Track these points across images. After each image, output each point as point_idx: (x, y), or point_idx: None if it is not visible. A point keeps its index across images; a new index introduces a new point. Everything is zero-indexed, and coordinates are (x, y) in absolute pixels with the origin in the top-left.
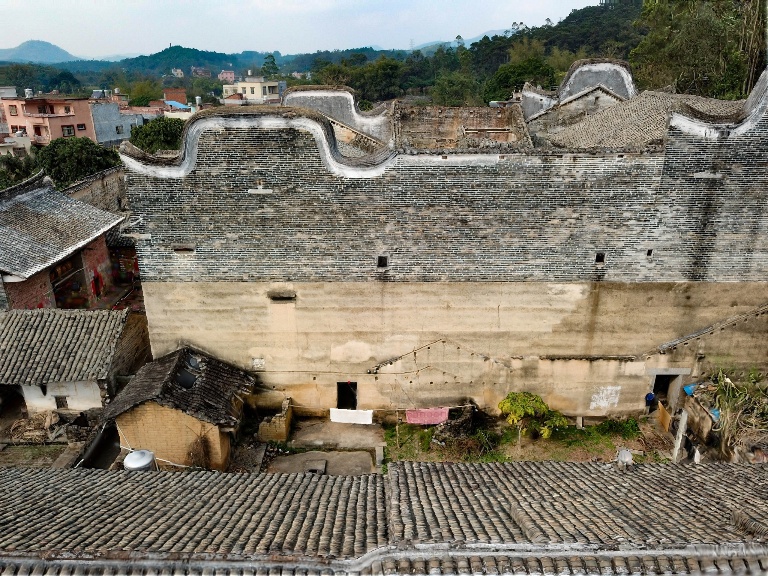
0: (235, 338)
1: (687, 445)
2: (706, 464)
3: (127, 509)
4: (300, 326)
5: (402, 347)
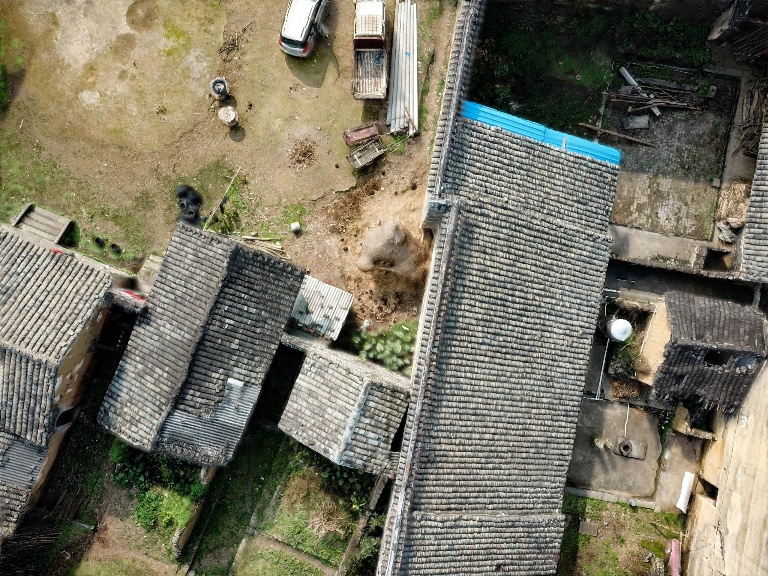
0: (764, 406)
1: None
2: None
3: (515, 358)
4: (761, 474)
5: (730, 566)
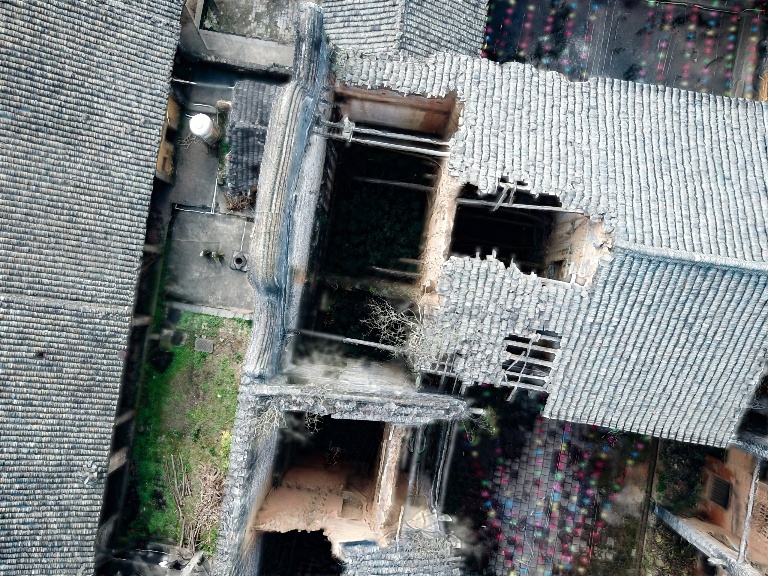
0: None
1: (175, 564)
2: (92, 540)
3: (51, 138)
4: None
5: None
